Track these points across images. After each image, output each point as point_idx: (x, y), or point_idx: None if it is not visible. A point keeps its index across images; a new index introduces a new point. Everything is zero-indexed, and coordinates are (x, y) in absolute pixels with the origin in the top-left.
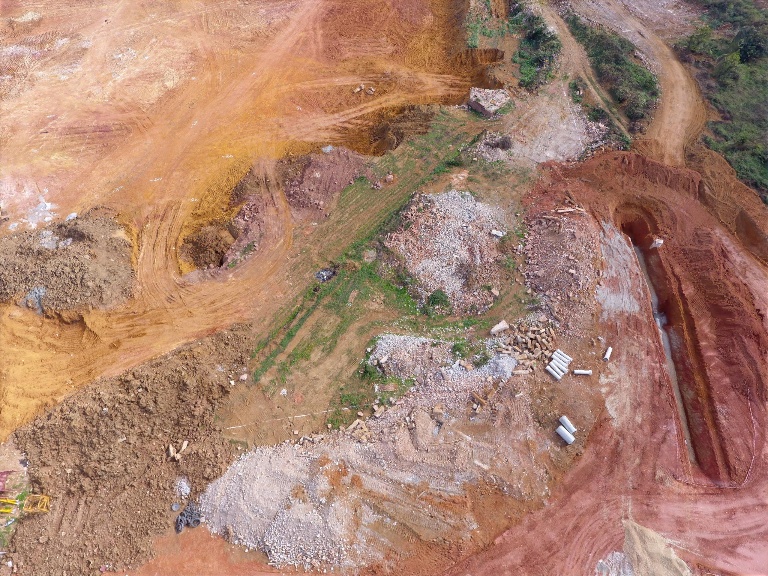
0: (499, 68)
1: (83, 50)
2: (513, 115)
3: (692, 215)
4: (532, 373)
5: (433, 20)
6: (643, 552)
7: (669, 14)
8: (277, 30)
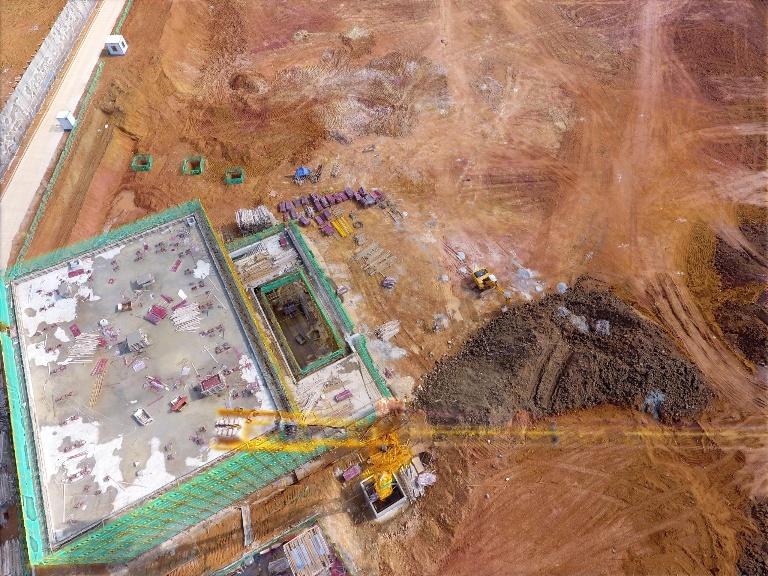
0: None
1: (442, 78)
2: None
3: None
4: None
5: None
6: None
7: None
8: (634, 61)
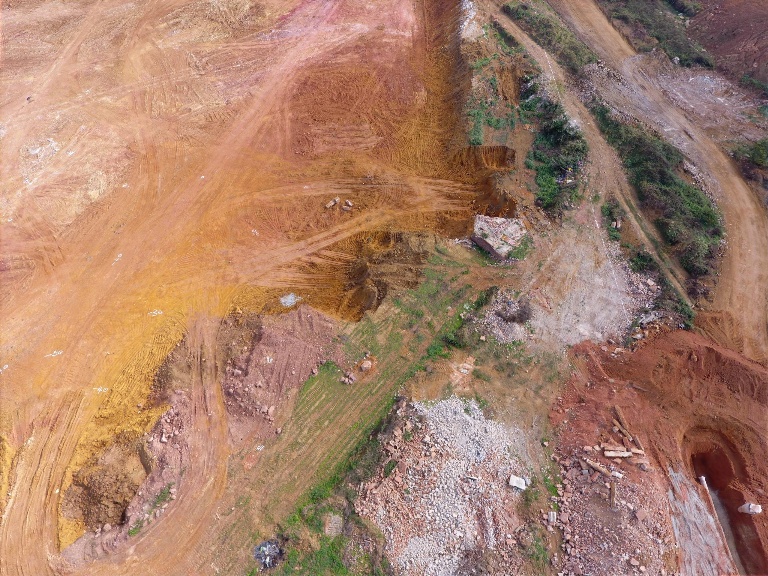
0: (510, 177)
1: None
2: (531, 260)
3: None
4: None
5: (427, 98)
6: None
7: (720, 104)
8: (236, 112)
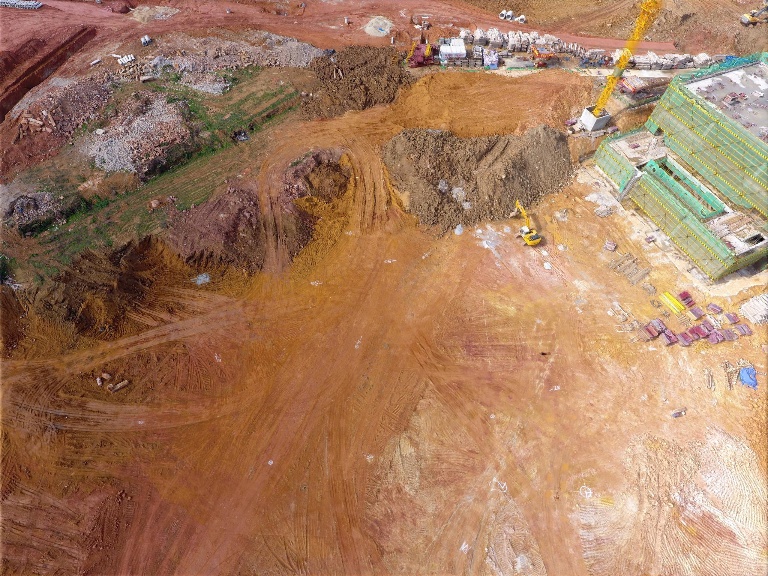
0: None
1: None
2: None
3: None
4: None
5: None
6: None
7: None
8: None
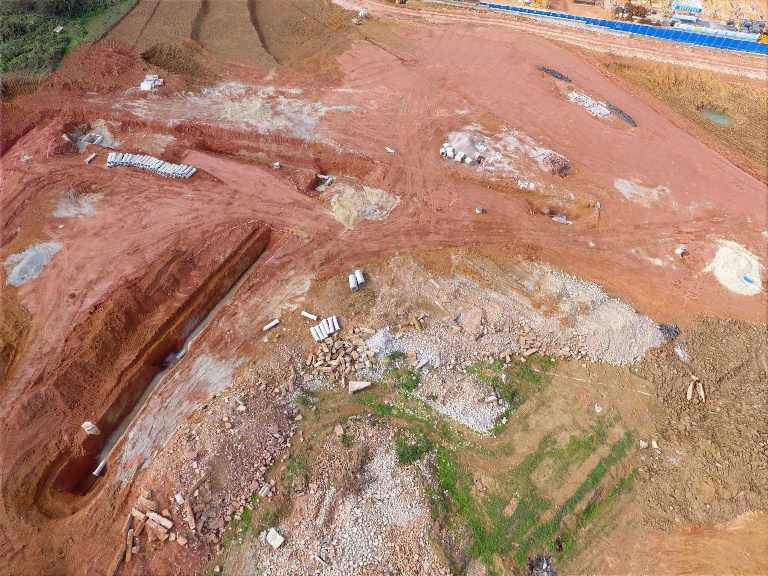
0: None
1: None
2: None
3: None
4: None
5: None
6: (353, 213)
7: None
8: None
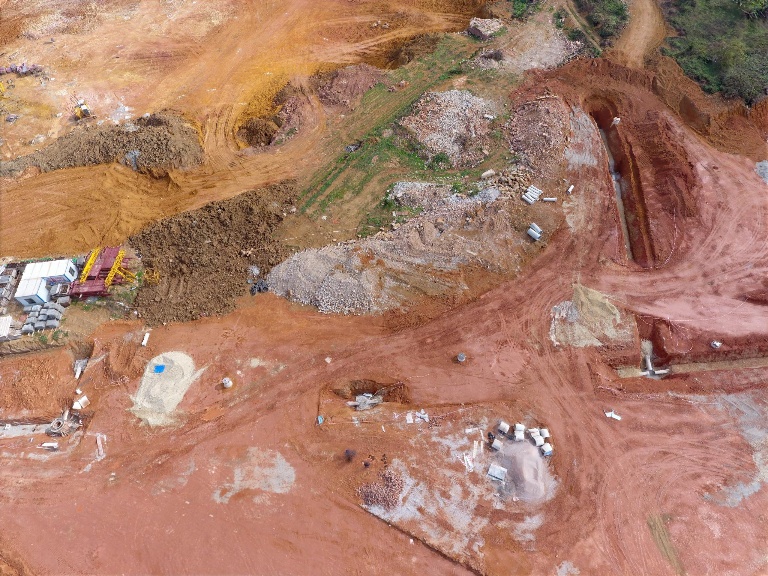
0: (495, 5)
1: None
2: (505, 37)
3: (645, 102)
4: (511, 199)
5: None
6: (586, 300)
7: None
8: None
